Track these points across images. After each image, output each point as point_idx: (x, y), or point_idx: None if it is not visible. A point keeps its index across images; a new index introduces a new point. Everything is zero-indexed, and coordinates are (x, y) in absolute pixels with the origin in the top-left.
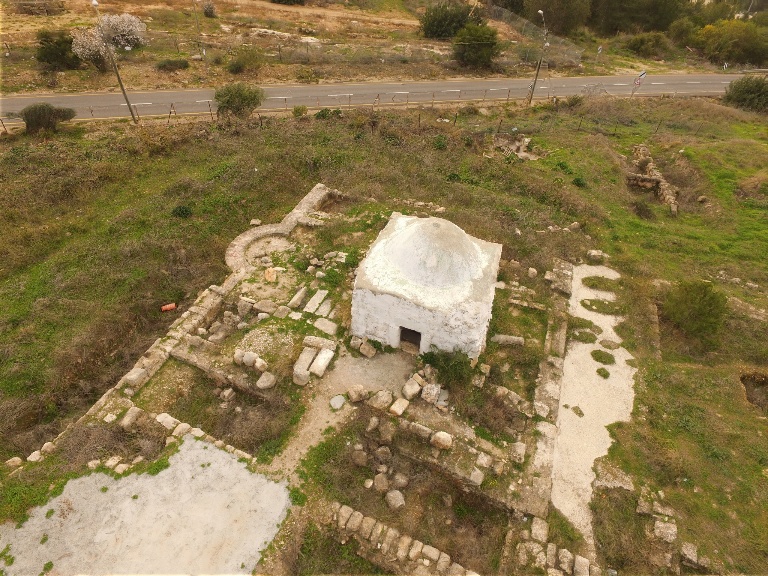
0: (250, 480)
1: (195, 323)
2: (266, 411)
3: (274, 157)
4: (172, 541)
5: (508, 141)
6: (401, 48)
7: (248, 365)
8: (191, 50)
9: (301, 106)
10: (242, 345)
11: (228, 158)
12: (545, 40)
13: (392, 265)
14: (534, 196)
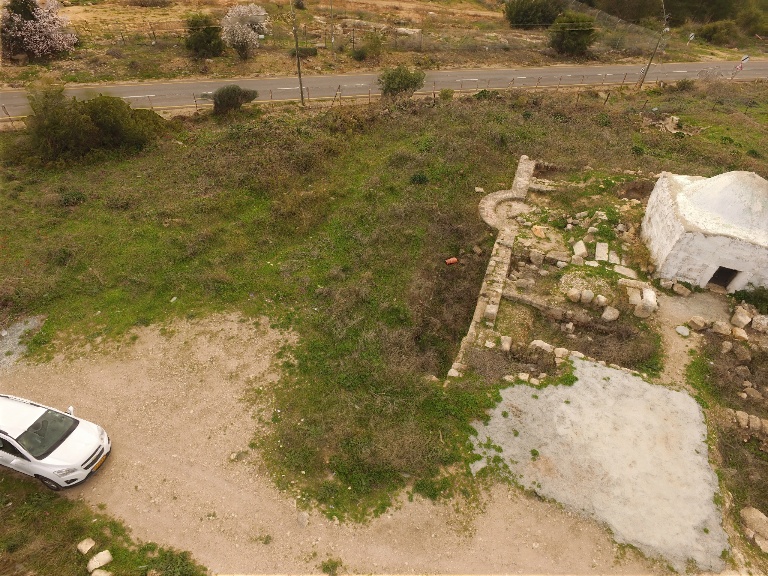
0: (655, 389)
1: (506, 270)
2: (618, 339)
3: (465, 133)
4: (624, 434)
5: (652, 120)
6: (493, 37)
7: (586, 302)
8: (310, 39)
9: (447, 89)
10: (564, 287)
11: (422, 134)
12: (664, 25)
13: (708, 213)
14: (721, 166)
